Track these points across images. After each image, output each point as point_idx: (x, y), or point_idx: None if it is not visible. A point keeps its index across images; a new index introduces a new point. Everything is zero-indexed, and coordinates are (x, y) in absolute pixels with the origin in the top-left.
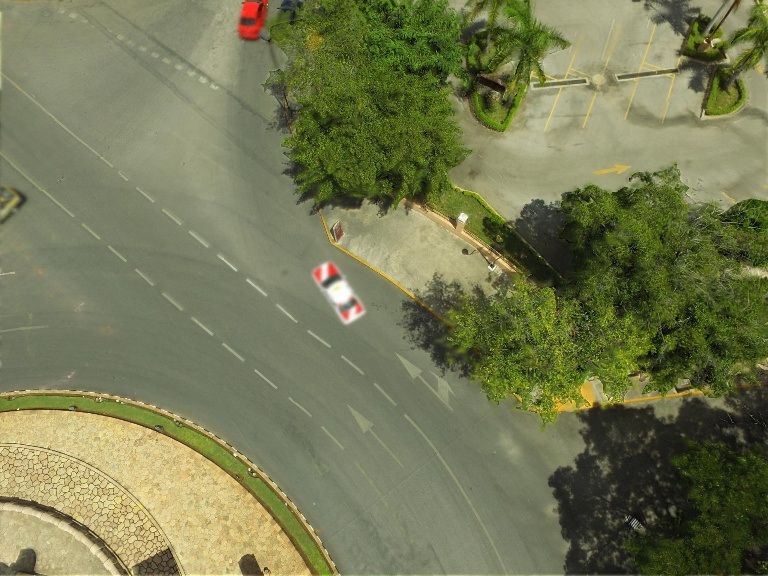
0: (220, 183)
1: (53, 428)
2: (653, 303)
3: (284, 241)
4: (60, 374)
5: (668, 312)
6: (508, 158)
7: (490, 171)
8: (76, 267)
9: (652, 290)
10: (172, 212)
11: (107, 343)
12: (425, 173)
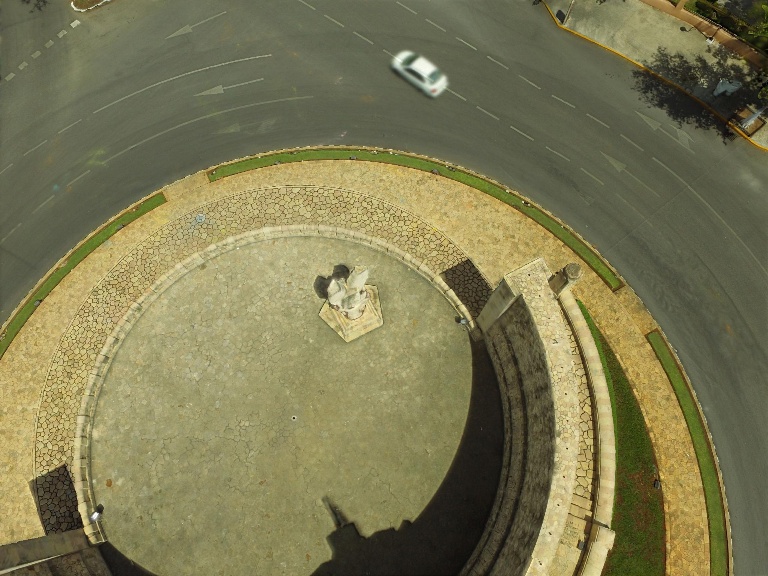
0: None
1: (340, 173)
2: None
3: (514, 26)
4: (333, 134)
5: None
6: None
7: None
8: (328, 49)
9: None
10: (406, 4)
11: (371, 108)
12: None
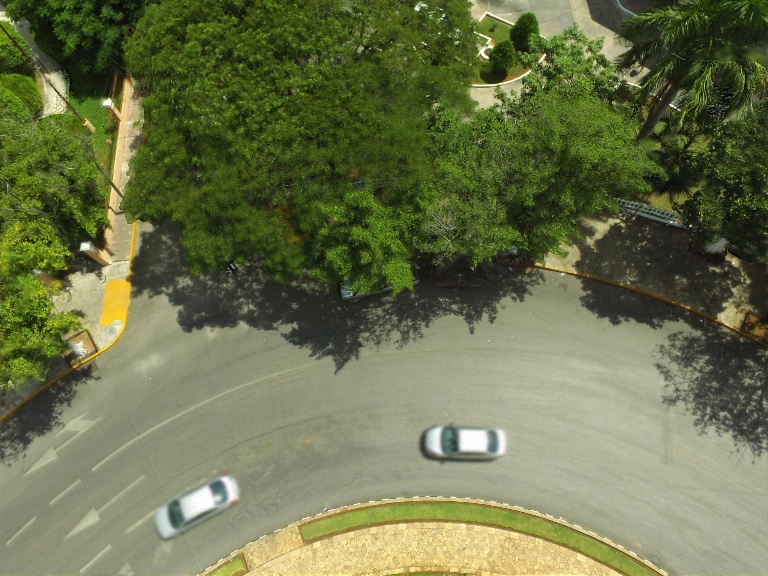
0: None
1: None
2: None
3: None
4: None
5: (1, 201)
6: None
7: None
8: None
9: None
10: None
11: None
12: None
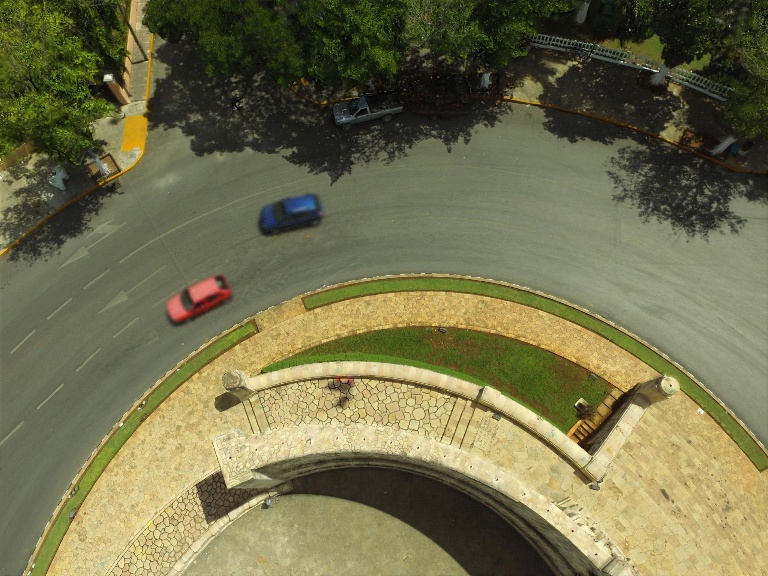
0: None
1: None
2: None
3: None
4: None
5: None
6: None
7: None
8: None
9: None
10: None
11: None
12: None
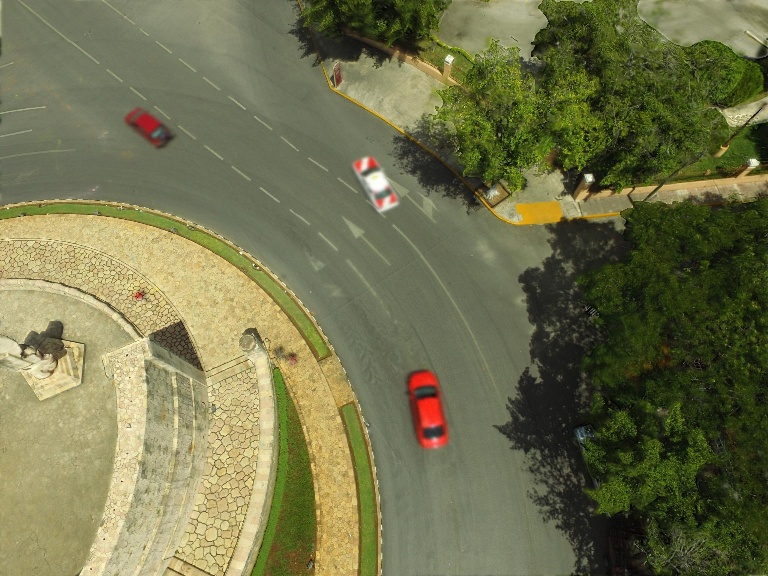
0: (232, 39)
1: (79, 228)
2: (609, 97)
3: (289, 87)
4: (86, 188)
5: (621, 104)
6: (492, 23)
7: (476, 33)
8: (101, 103)
9: (607, 81)
10: (188, 61)
11: (128, 164)
12: (415, 5)
